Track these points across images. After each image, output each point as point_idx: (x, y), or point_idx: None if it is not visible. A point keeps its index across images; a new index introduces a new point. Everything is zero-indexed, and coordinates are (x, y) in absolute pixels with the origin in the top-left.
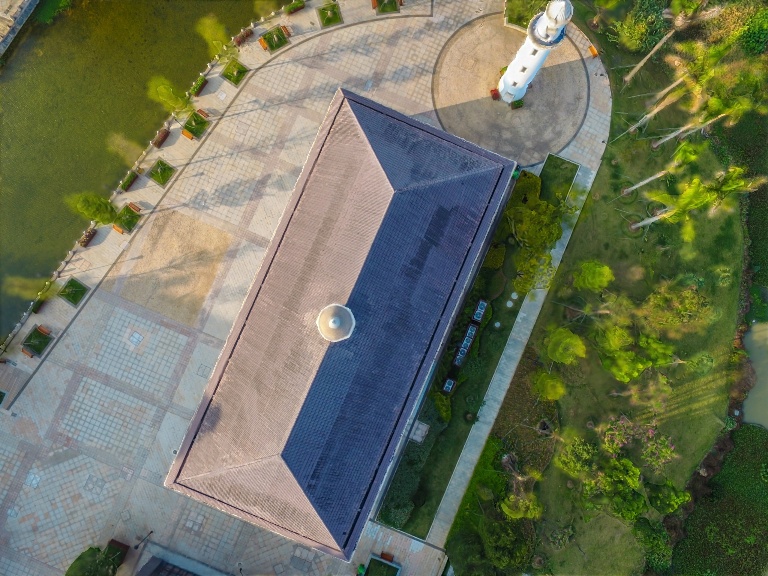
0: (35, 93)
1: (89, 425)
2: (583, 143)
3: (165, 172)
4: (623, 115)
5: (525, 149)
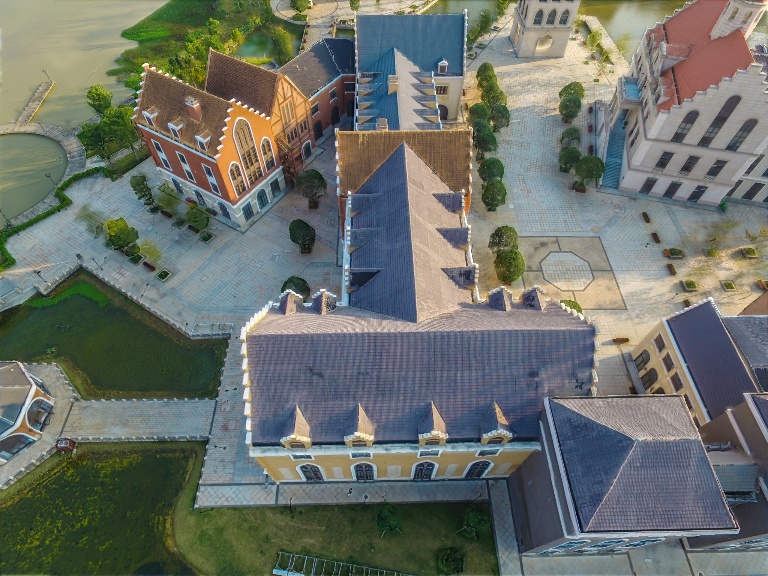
0: None
1: None
2: None
3: None
4: None
5: None
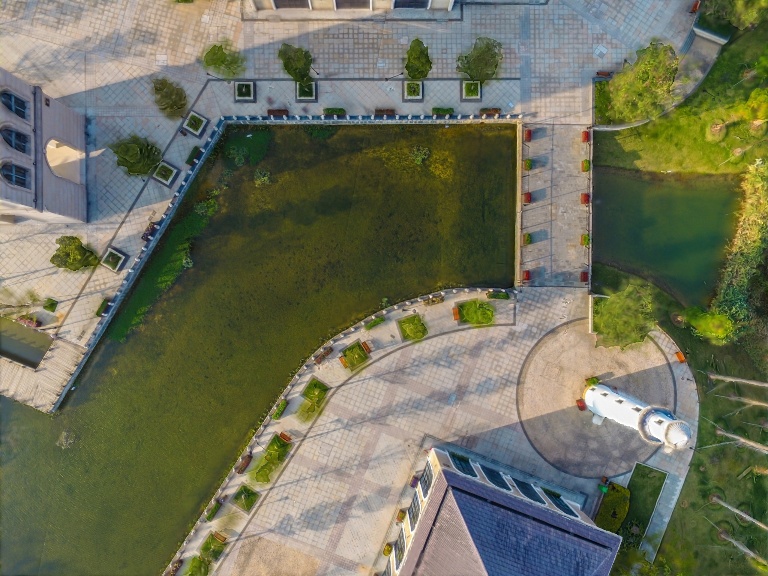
0: (111, 414)
1: None
2: None
3: (249, 498)
4: (710, 418)
5: (612, 458)
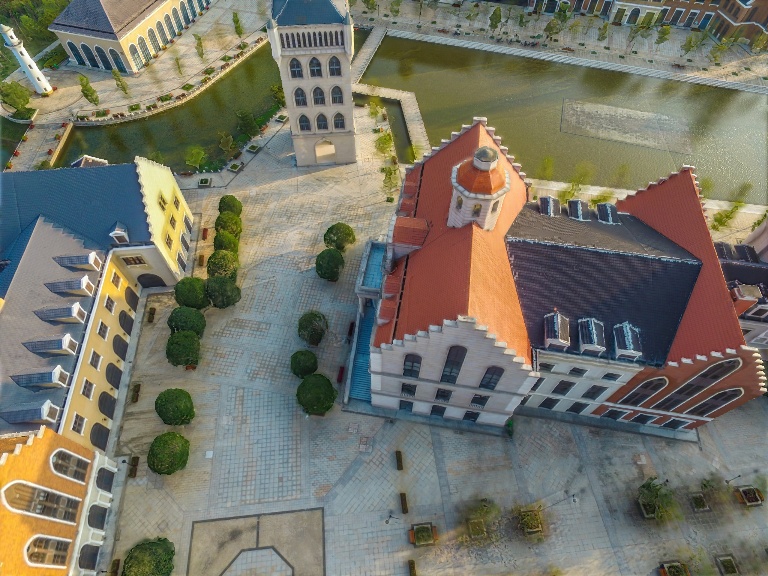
0: None
1: (259, 4)
2: (16, 79)
3: None
4: None
5: None
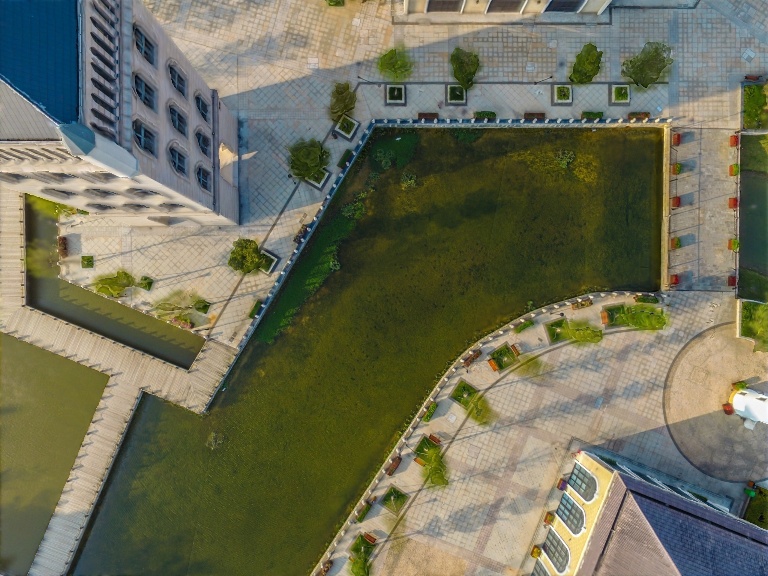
0: (259, 415)
1: None
2: None
3: (398, 500)
4: None
5: (758, 463)
